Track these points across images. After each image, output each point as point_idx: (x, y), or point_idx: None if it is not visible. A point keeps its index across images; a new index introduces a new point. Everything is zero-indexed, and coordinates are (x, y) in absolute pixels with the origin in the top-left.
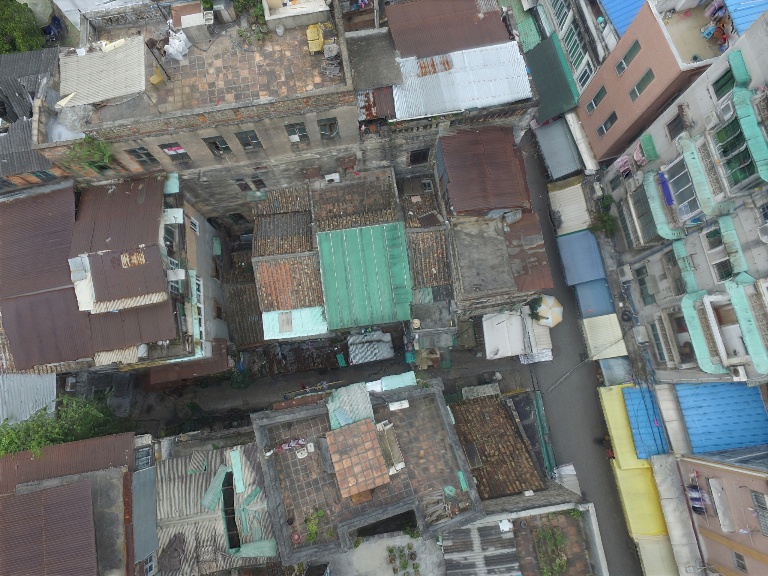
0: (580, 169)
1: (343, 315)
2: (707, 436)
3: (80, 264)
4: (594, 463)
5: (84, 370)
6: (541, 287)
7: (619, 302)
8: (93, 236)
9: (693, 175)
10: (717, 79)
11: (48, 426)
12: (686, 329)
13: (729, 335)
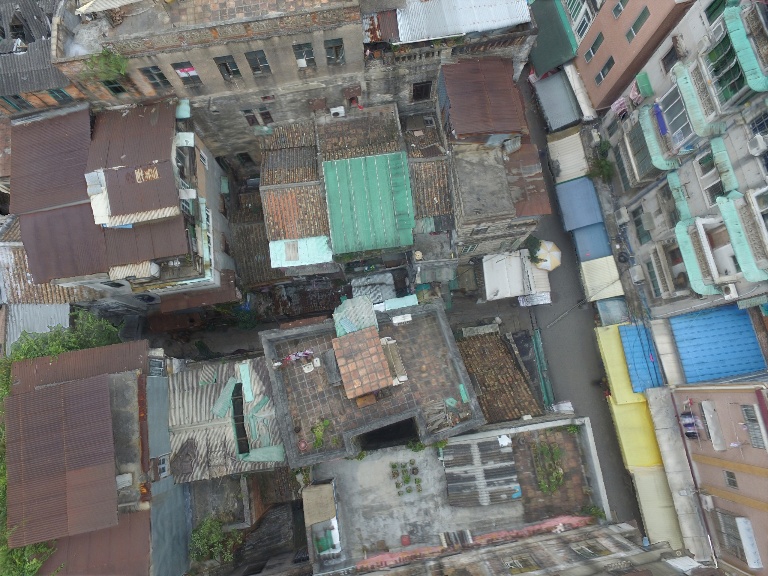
0: (578, 119)
1: (348, 240)
2: (700, 366)
3: (96, 179)
4: (591, 404)
5: (96, 304)
6: (539, 213)
7: (616, 244)
8: (108, 154)
9: (686, 99)
10: (709, 4)
11: (65, 335)
12: (680, 260)
13: (721, 256)
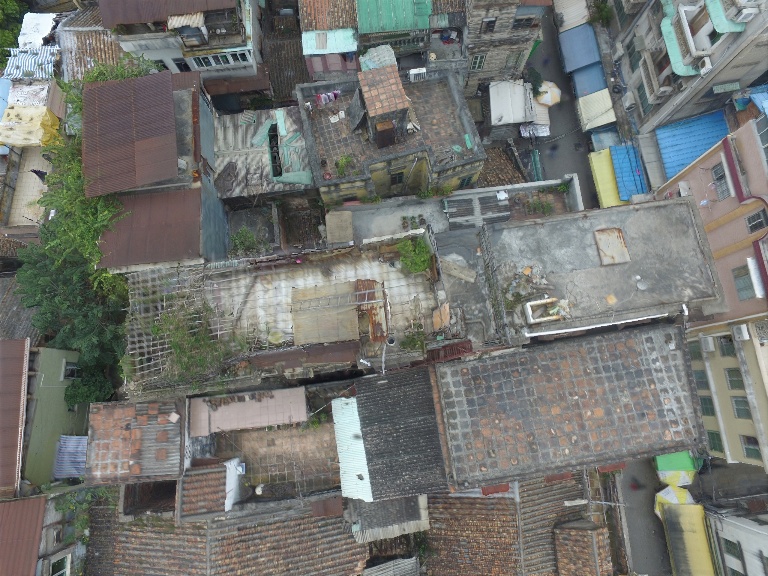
0: None
1: (372, 23)
2: (681, 167)
3: None
4: None
5: None
6: (541, 3)
7: (611, 77)
8: None
9: None
10: None
11: (129, 69)
12: (666, 66)
13: (699, 39)
